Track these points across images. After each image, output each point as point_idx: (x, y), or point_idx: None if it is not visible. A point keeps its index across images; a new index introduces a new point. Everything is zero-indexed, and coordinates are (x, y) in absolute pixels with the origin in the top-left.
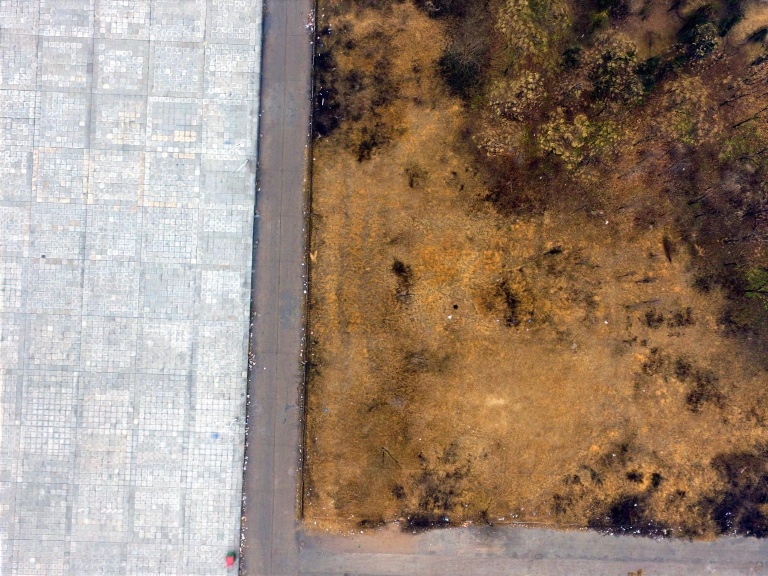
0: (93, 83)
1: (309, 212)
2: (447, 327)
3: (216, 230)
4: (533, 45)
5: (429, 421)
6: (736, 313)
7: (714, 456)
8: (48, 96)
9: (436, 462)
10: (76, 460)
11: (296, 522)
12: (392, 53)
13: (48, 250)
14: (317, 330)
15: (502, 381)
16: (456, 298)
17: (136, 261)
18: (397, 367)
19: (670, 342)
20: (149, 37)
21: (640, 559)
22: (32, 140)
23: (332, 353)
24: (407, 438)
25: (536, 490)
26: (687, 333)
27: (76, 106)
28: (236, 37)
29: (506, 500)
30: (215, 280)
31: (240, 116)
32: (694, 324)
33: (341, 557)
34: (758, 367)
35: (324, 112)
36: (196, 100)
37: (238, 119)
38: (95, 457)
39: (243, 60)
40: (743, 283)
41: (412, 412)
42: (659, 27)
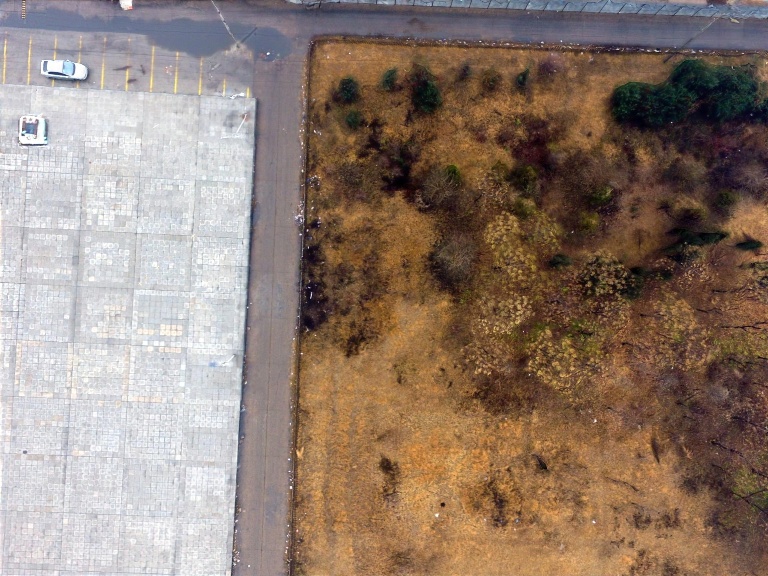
0: (79, 276)
1: (296, 407)
2: (434, 526)
3: (201, 426)
4: (521, 272)
5: None
6: (724, 515)
7: None
8: (32, 289)
9: None
10: None
11: None
12: (381, 247)
13: (30, 446)
14: (303, 528)
15: None
16: (443, 496)
17: (119, 457)
18: (383, 567)
19: (658, 544)
20: (136, 229)
21: None
22: (15, 333)
23: (317, 552)
24: None
25: None
26: (675, 535)
27: (61, 299)
28: (224, 230)
29: None
30: (200, 477)
31: (227, 310)
32: (682, 527)
33: None
34: (745, 571)
35: (312, 306)
36: (183, 293)
37: (225, 313)
38: None
39: (231, 253)
40: (731, 484)
41: None
42: (648, 224)
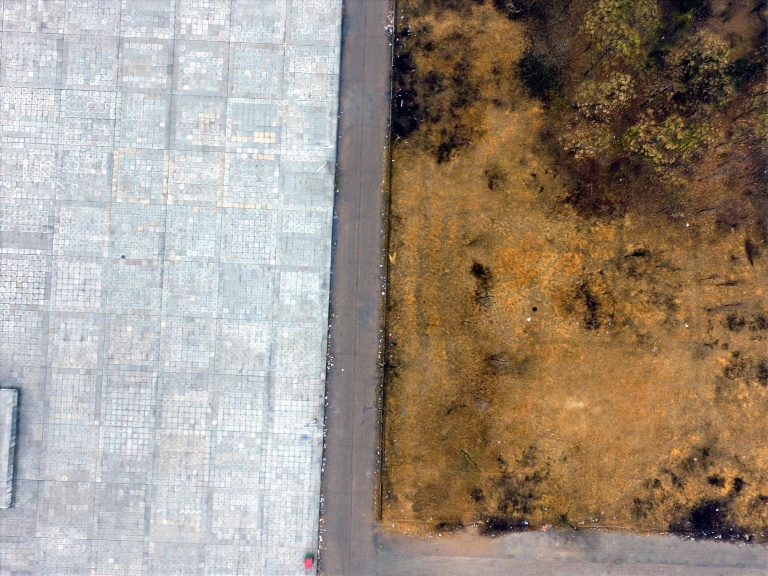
0: (173, 84)
1: (388, 213)
2: (526, 329)
3: (295, 231)
4: (626, 47)
5: (508, 424)
6: None
7: None
8: (129, 97)
9: (515, 465)
10: (155, 461)
11: (374, 524)
12: (471, 55)
13: (128, 250)
14: (396, 332)
15: (582, 384)
16: (535, 300)
17: (215, 262)
18: (476, 369)
19: (752, 346)
20: (229, 38)
21: (721, 564)
22: (113, 141)
23: (411, 355)
24: (486, 441)
25: (616, 494)
26: None
27: (156, 107)
28: (316, 39)
29: (586, 504)
30: (294, 281)
31: (319, 117)
32: None
33: (419, 560)
34: None
35: (403, 114)
36: (276, 101)
37: (317, 120)
38: (174, 458)
39: (323, 61)
40: None
41: (491, 415)
42: (740, 29)
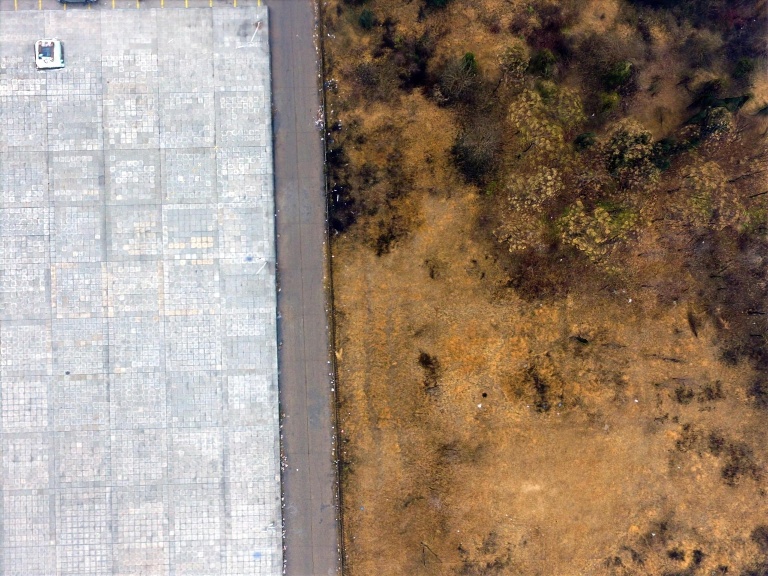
0: (106, 195)
1: (331, 310)
2: (477, 416)
3: (239, 334)
4: (549, 143)
5: (466, 512)
6: (765, 383)
7: (753, 529)
8: (62, 211)
9: (476, 553)
10: None
11: None
12: (404, 145)
13: (72, 366)
14: (347, 428)
15: (536, 467)
16: (484, 386)
17: (161, 371)
18: (430, 460)
19: (702, 417)
20: (159, 145)
21: None
22: (48, 257)
23: (364, 450)
24: (445, 531)
25: (578, 575)
26: (718, 407)
27: (90, 219)
28: (246, 139)
29: None
30: (242, 385)
31: (256, 218)
32: (724, 398)
33: None
34: None
35: (340, 208)
36: (211, 205)
37: (254, 221)
38: (133, 572)
39: (255, 162)
40: None
41: (448, 504)
42: (669, 101)
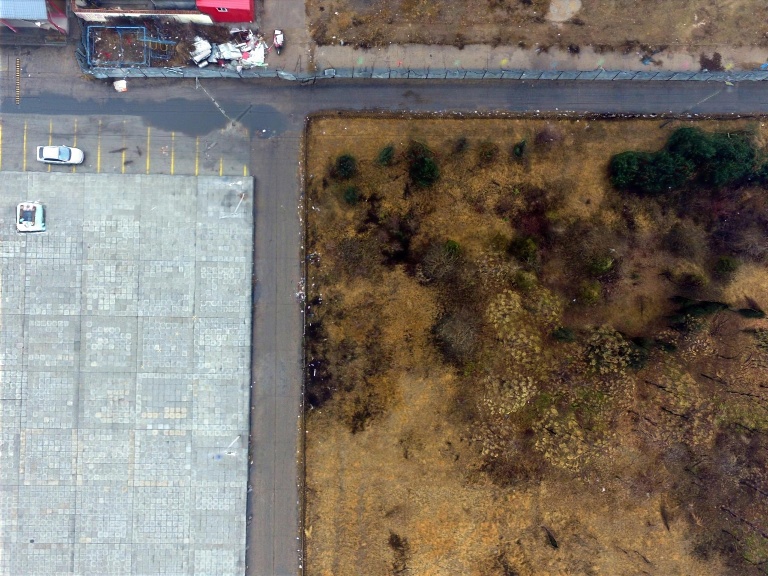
0: (81, 361)
1: (303, 485)
2: None
3: (209, 508)
4: (525, 355)
5: None
6: None
7: None
8: (35, 376)
9: None
10: None
11: None
12: (384, 322)
13: (37, 534)
14: None
15: None
16: (454, 570)
17: (127, 543)
18: None
19: None
20: (137, 313)
21: None
22: (19, 422)
23: None
24: None
25: None
26: None
27: (64, 385)
28: (226, 310)
29: None
30: (208, 560)
31: (231, 390)
32: None
33: None
34: None
35: (316, 383)
36: (186, 375)
37: (229, 394)
38: None
39: (233, 333)
40: None
41: None
42: (650, 290)
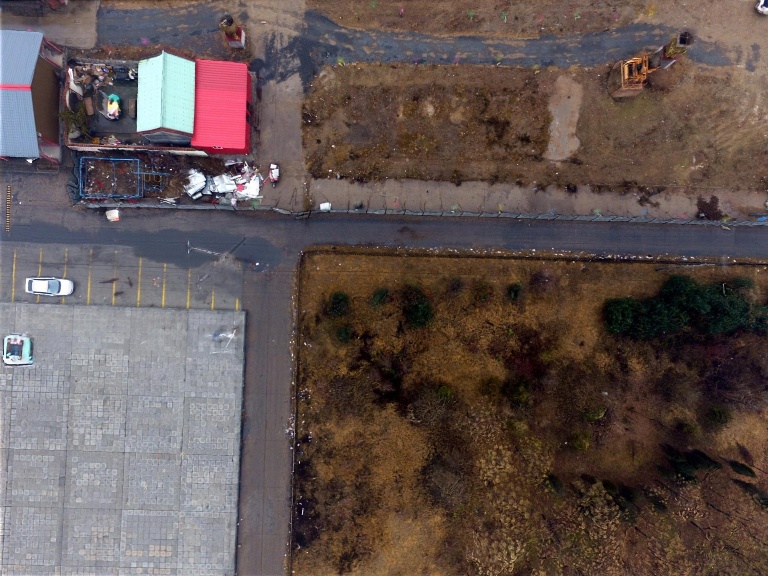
0: (65, 497)
1: None
2: None
3: None
4: (515, 521)
5: None
6: None
7: None
8: (18, 512)
9: None
10: None
11: None
12: (373, 462)
13: None
14: None
15: None
16: None
17: None
18: None
19: None
20: (124, 448)
21: None
22: (1, 558)
23: None
24: None
25: None
26: None
27: (47, 521)
28: (214, 447)
29: None
30: None
31: (217, 529)
32: None
33: None
34: None
35: (304, 522)
36: (172, 513)
37: (215, 532)
38: None
39: (221, 471)
40: None
41: None
42: (642, 435)
